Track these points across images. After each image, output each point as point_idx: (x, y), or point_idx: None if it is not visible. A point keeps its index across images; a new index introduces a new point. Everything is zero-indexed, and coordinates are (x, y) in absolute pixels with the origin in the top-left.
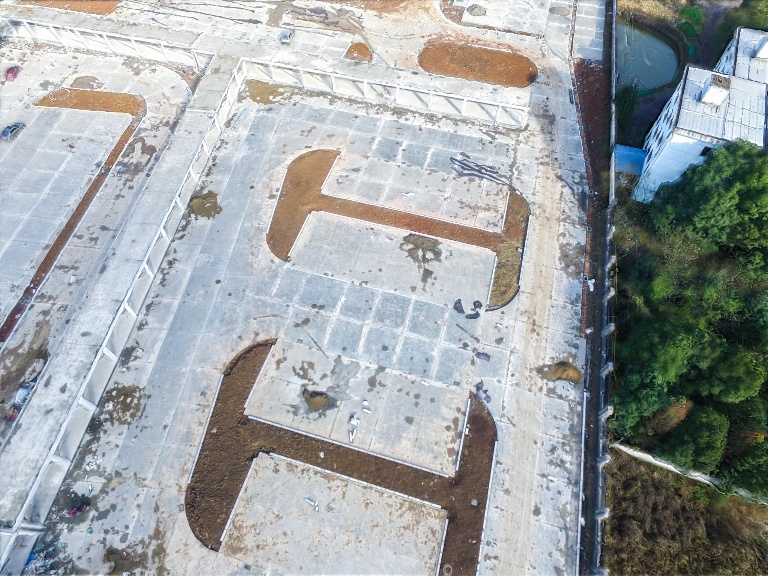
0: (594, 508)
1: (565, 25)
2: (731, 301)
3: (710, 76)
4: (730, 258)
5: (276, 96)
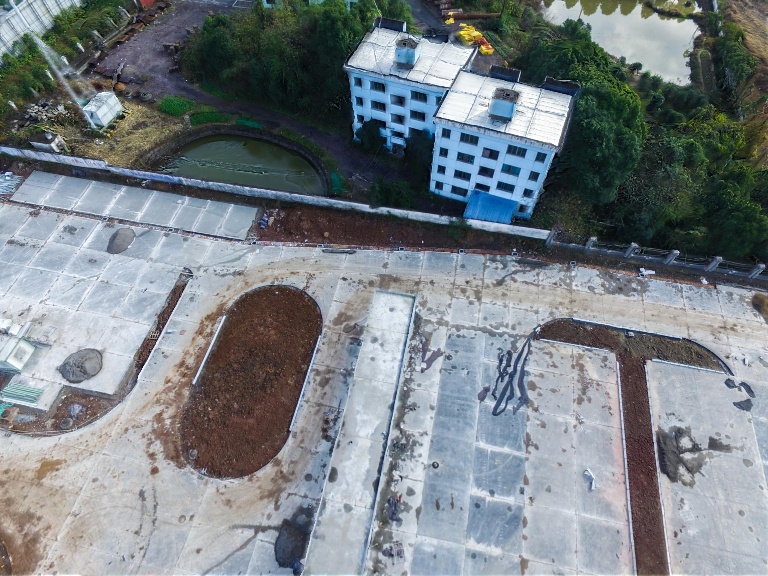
0: None
1: (162, 238)
2: (684, 168)
3: (493, 101)
4: None
5: None
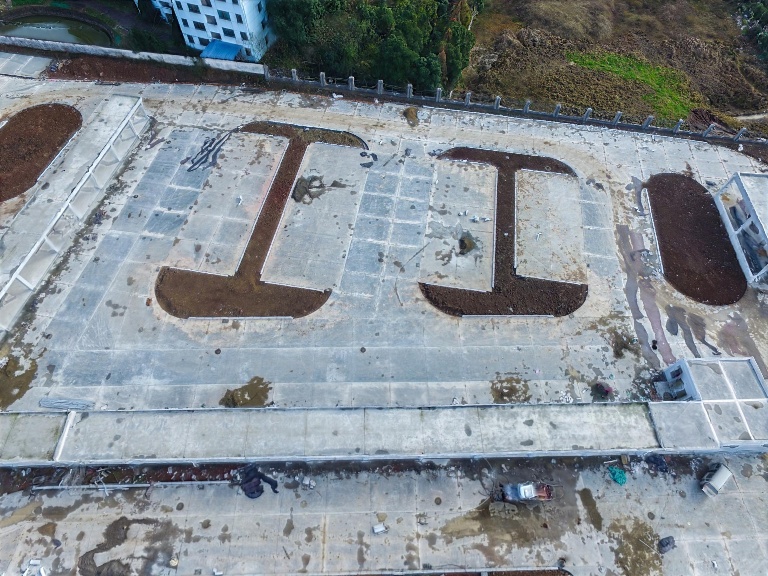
0: (493, 109)
1: None
2: (366, 21)
3: None
4: (333, 14)
5: (17, 366)
